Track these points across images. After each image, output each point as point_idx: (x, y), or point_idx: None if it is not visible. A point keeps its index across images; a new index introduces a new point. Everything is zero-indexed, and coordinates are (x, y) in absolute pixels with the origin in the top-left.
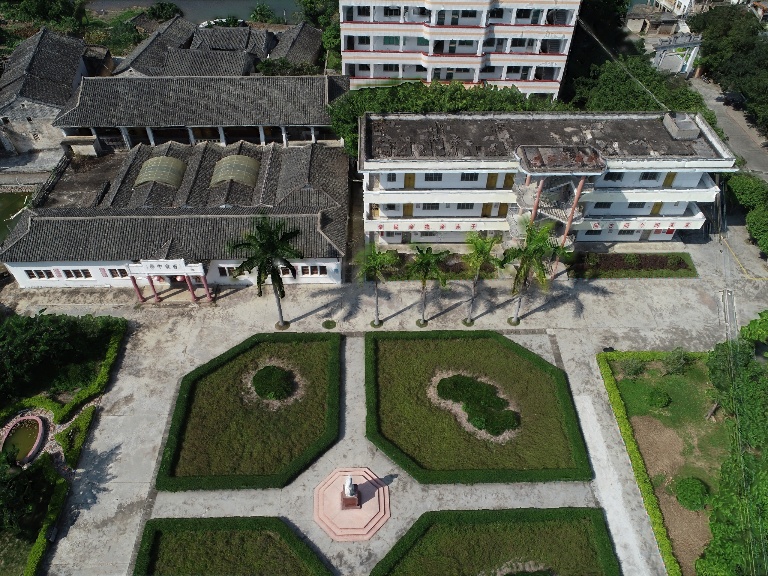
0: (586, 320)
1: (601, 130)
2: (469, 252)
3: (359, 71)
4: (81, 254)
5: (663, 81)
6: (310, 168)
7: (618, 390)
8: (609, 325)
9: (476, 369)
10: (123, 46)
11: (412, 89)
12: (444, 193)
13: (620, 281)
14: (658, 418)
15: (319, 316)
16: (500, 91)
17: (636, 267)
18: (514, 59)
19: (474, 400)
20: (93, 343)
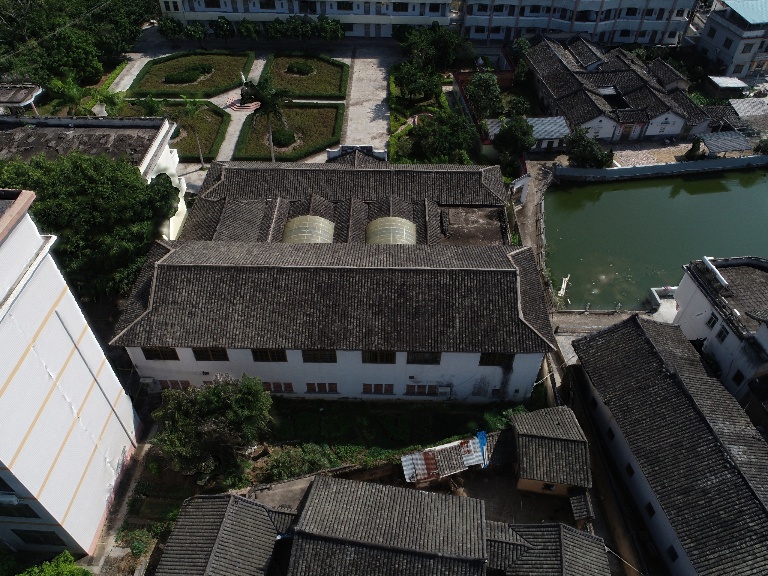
0: None
1: None
2: None
3: None
4: None
5: None
6: None
7: None
8: None
9: None
10: None
11: (67, 171)
12: None
13: None
14: None
15: None
16: None
17: None
18: None
19: None
20: None
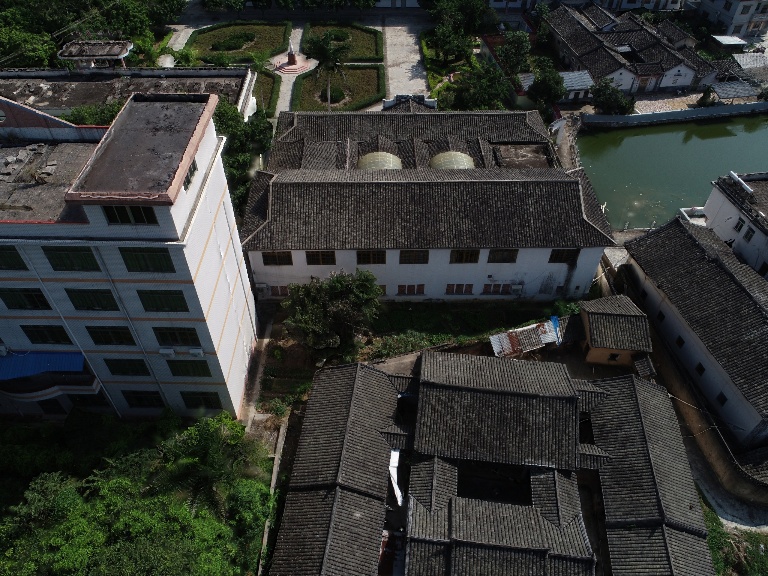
0: None
1: None
2: None
3: None
4: None
5: None
6: None
7: None
8: None
9: None
10: (765, 563)
11: None
12: None
13: None
14: None
15: None
16: None
17: None
18: None
19: None
20: None
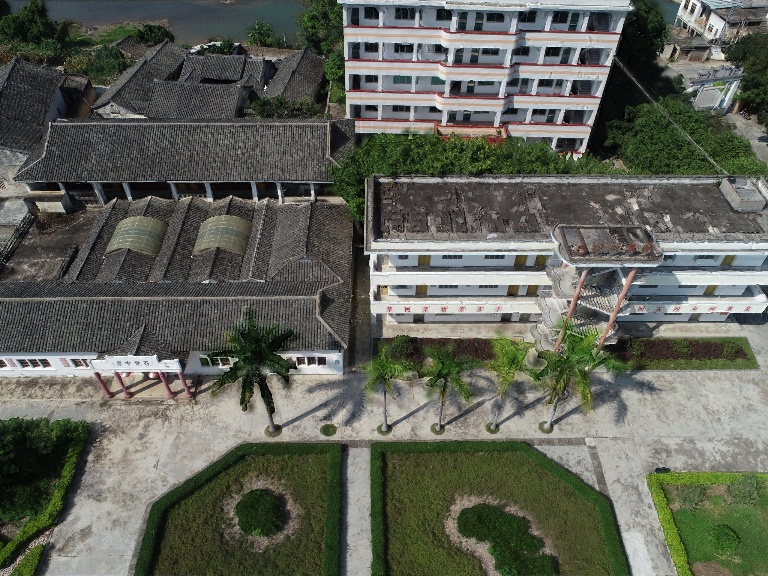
0: (631, 426)
1: (649, 198)
2: (491, 334)
3: (365, 111)
4: (37, 344)
5: (709, 128)
6: (308, 234)
7: (676, 528)
8: (659, 433)
9: (503, 495)
10: (107, 74)
11: (428, 147)
12: (465, 275)
13: (668, 373)
14: (726, 566)
15: (317, 418)
16: (529, 147)
17: (687, 357)
18: (540, 101)
19: (502, 541)
20: (48, 454)
